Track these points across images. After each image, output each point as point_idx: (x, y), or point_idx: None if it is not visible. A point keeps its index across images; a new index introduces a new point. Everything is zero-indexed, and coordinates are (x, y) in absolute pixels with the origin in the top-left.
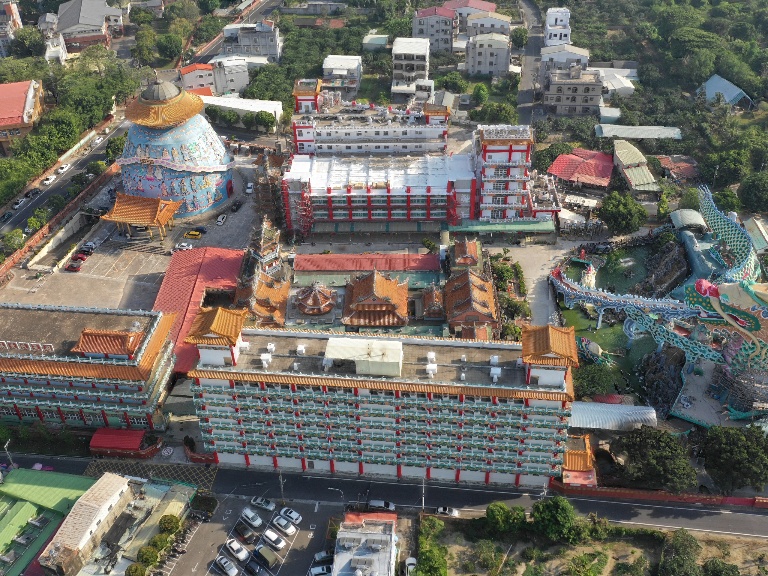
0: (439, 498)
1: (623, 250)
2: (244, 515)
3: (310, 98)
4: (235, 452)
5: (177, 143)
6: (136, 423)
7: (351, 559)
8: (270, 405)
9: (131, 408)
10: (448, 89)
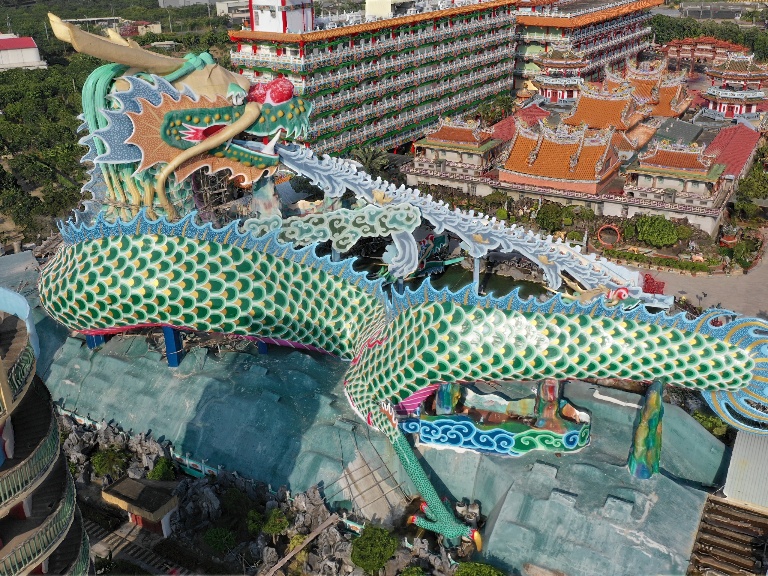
0: None
1: (747, 422)
2: None
3: None
4: None
5: None
6: None
7: None
8: None
9: None
10: None
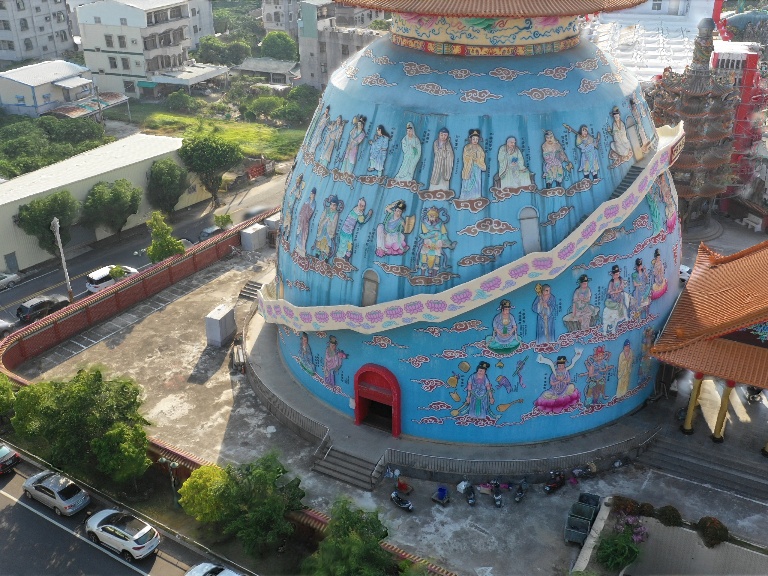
0: None
1: None
2: None
3: None
4: None
5: None
6: None
7: None
8: None
9: None
10: (223, 65)
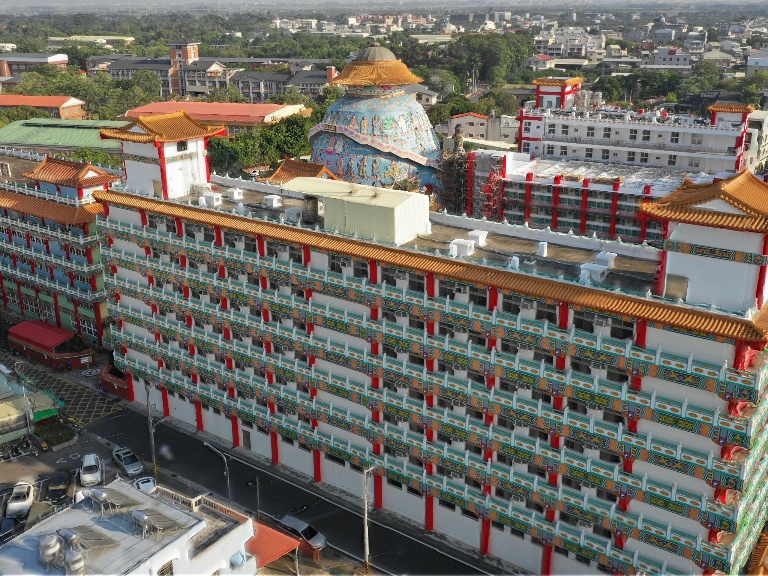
0: (422, 566)
1: None
2: (81, 461)
3: (555, 90)
4: (147, 378)
5: (370, 112)
6: (87, 331)
7: (80, 525)
8: (186, 275)
9: (71, 289)
10: None
